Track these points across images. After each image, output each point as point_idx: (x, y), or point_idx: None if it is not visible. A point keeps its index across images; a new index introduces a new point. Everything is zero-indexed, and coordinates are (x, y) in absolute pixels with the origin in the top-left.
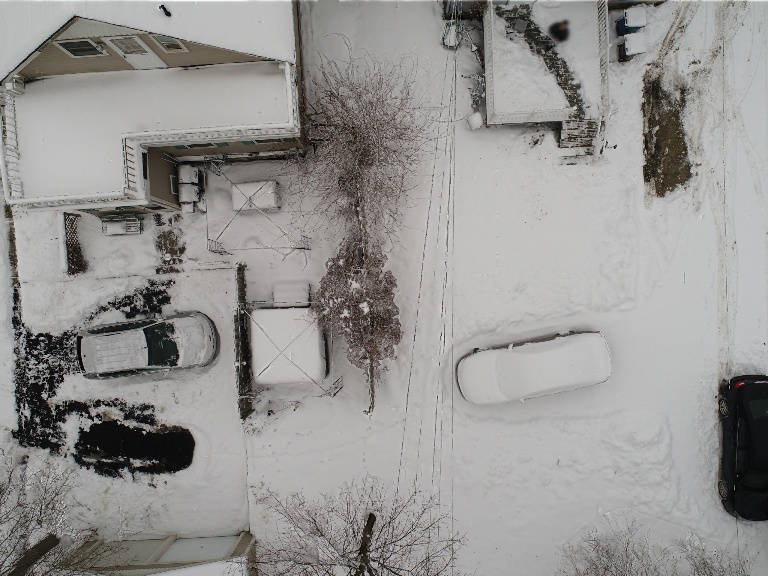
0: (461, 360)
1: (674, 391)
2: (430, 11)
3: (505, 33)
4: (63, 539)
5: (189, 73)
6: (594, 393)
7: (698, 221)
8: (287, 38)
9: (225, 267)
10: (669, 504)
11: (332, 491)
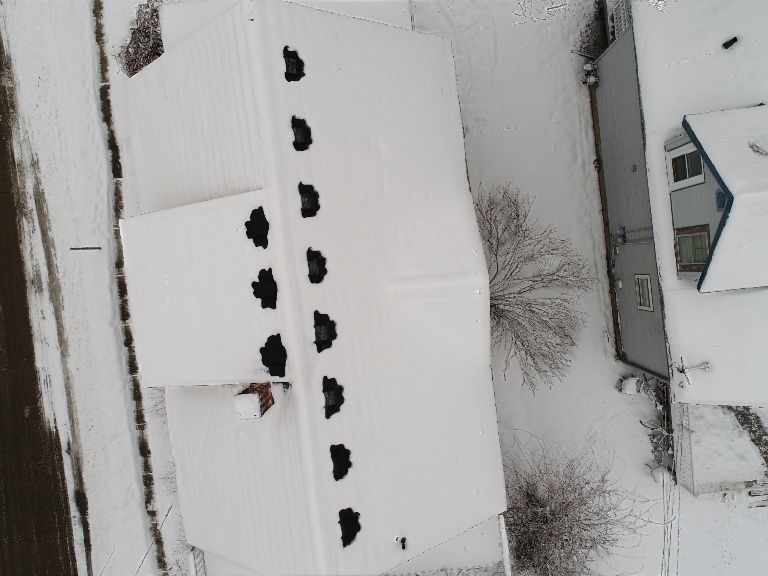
0: None
1: None
2: (601, 352)
3: None
4: None
5: None
6: None
7: None
8: (501, 491)
9: None
10: None
11: None
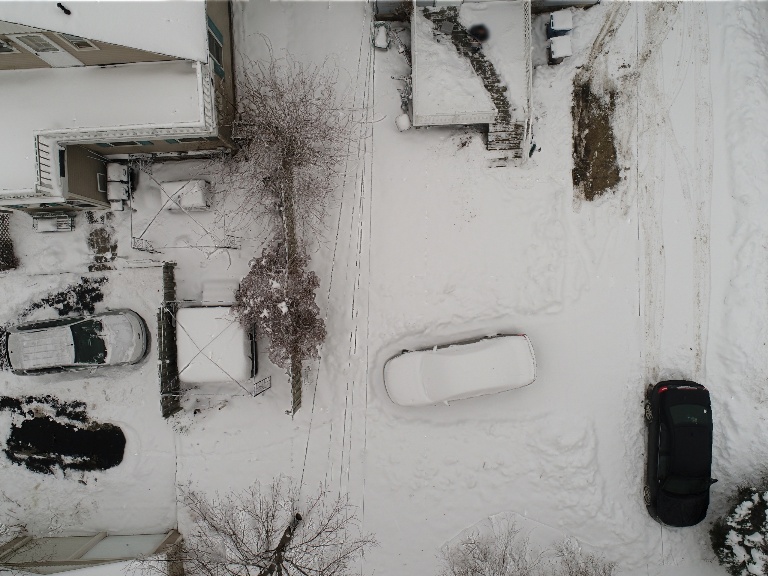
0: (388, 361)
1: (600, 395)
2: (361, 12)
3: (432, 35)
4: None
5: (105, 71)
6: (521, 396)
7: (626, 225)
8: (198, 37)
9: (156, 265)
10: (593, 508)
11: None
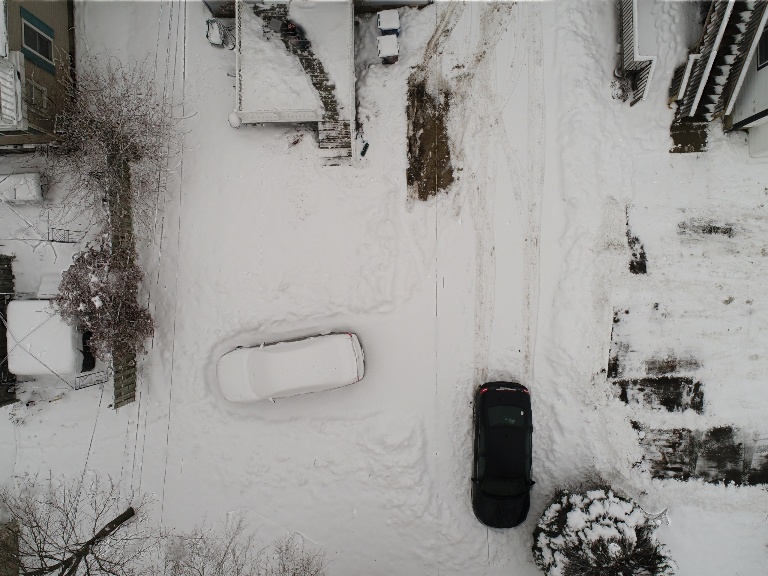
0: None
1: (430, 395)
2: (200, 8)
3: (262, 32)
4: None
5: None
6: (353, 395)
7: (457, 226)
8: None
9: None
10: (420, 508)
11: None
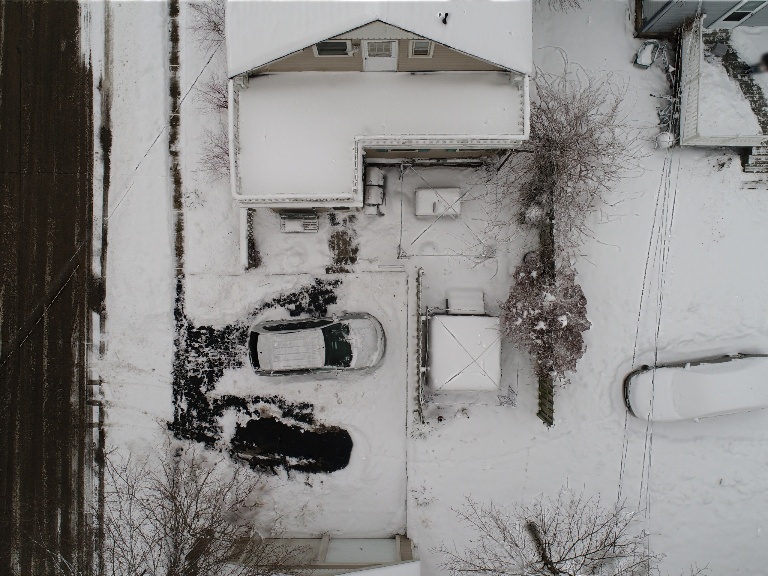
0: (633, 376)
1: None
2: (622, 28)
3: (703, 56)
4: (255, 537)
5: (417, 78)
6: (759, 415)
7: None
8: (529, 51)
9: (399, 271)
10: None
11: (493, 499)
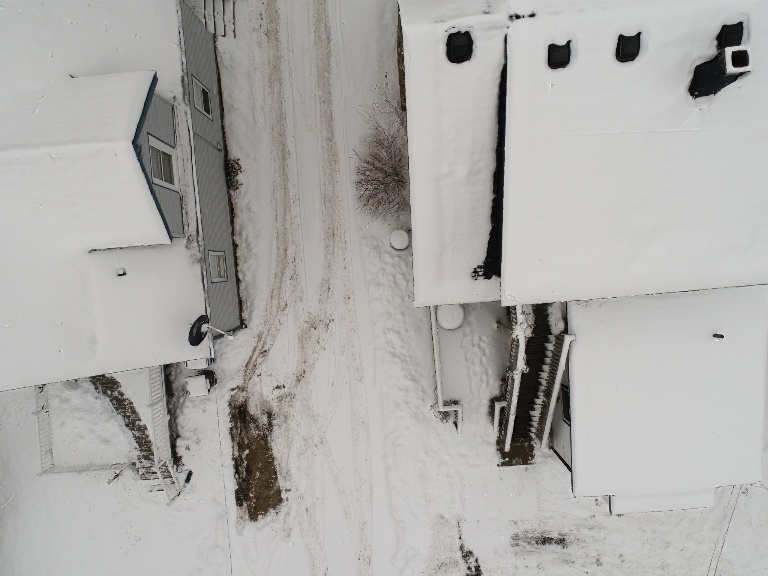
0: None
1: None
2: None
3: None
4: None
5: None
6: None
7: (289, 548)
8: None
9: None
10: None
11: None
